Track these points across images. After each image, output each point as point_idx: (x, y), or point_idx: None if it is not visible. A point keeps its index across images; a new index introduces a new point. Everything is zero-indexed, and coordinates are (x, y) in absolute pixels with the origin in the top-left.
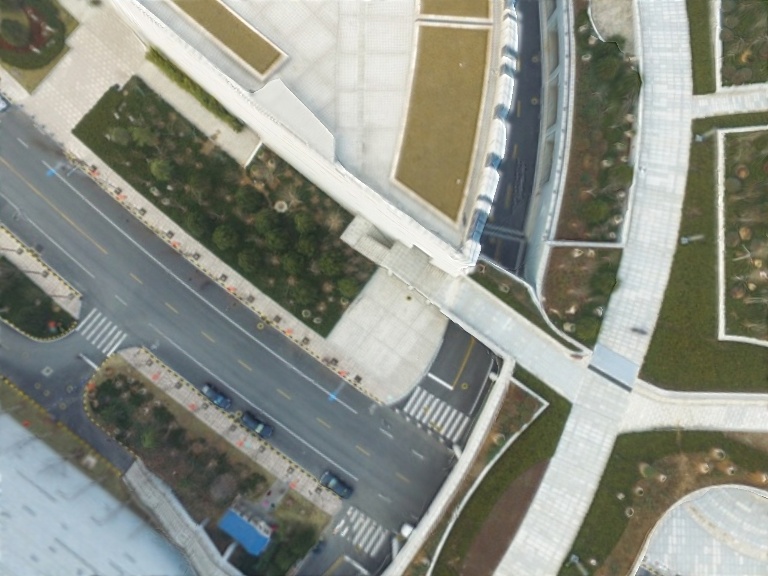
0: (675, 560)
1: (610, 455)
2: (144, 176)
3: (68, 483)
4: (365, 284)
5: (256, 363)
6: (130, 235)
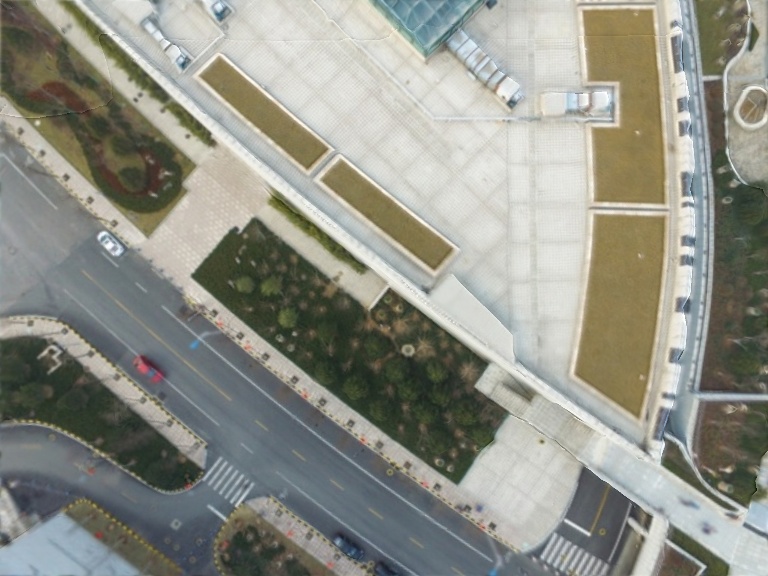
0: None
1: None
2: (269, 323)
3: None
4: (497, 429)
5: (387, 511)
6: (253, 380)
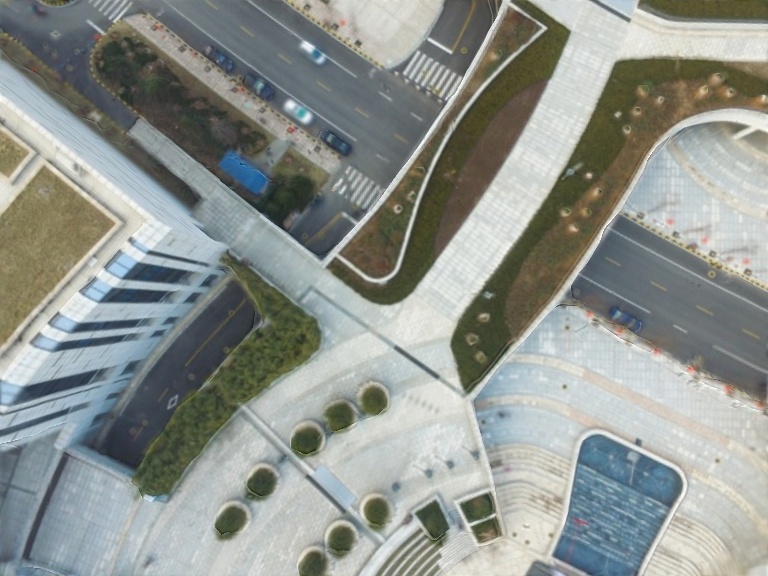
0: (673, 218)
1: (608, 79)
2: None
3: (73, 115)
4: None
5: (258, 30)
6: None
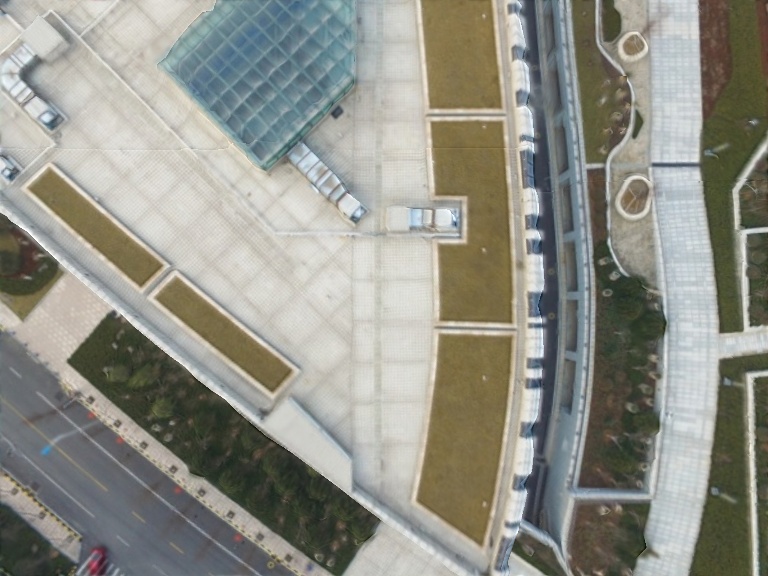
0: None
1: None
2: (145, 412)
3: None
4: (380, 521)
5: None
6: (131, 470)
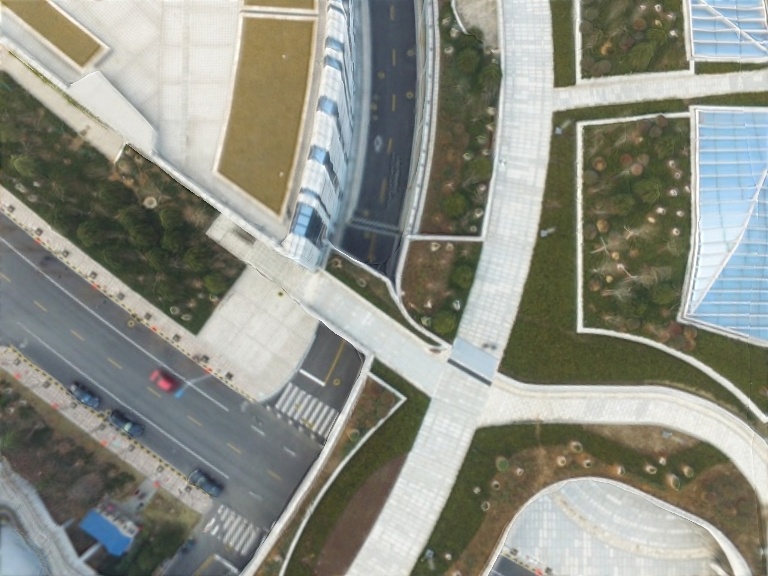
0: (546, 553)
1: (468, 449)
2: (10, 172)
3: None
4: (235, 280)
5: (126, 361)
6: None
